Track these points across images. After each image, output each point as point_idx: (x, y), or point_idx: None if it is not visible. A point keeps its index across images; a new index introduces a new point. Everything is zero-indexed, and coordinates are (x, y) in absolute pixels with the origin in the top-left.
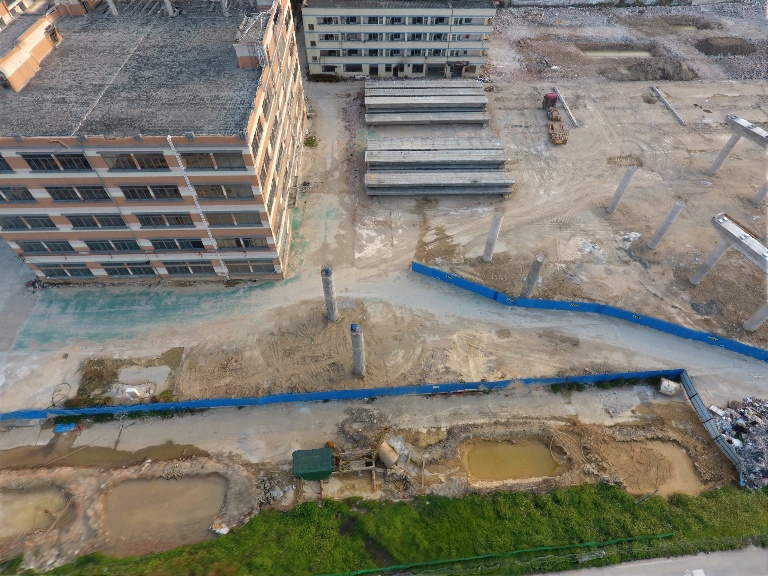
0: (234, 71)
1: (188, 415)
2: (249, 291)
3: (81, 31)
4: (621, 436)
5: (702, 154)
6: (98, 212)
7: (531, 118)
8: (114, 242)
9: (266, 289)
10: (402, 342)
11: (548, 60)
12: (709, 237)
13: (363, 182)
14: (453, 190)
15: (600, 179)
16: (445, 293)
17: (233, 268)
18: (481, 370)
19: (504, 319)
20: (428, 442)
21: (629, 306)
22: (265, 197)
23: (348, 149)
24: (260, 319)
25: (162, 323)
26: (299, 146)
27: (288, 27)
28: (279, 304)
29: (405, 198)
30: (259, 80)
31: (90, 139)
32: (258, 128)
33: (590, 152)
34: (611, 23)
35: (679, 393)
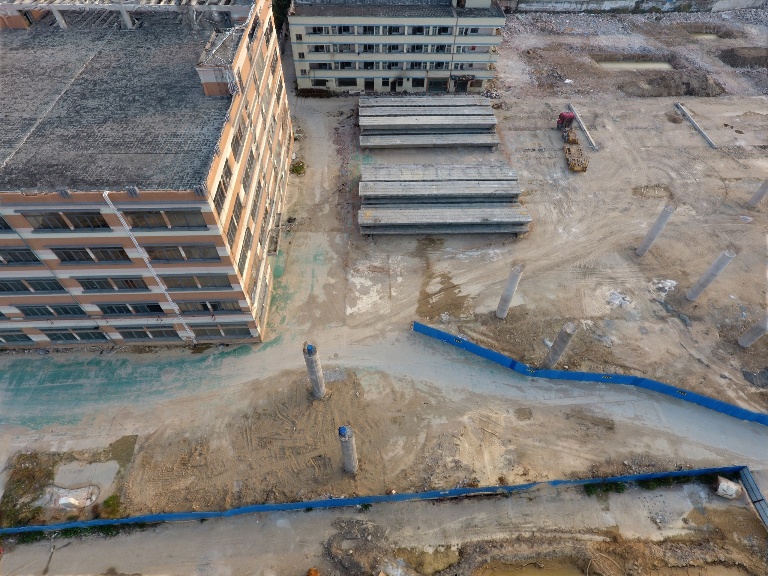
0: (198, 100)
1: (137, 531)
2: (220, 358)
3: (19, 48)
4: (674, 559)
5: (738, 183)
6: (28, 276)
7: (545, 140)
8: (53, 307)
9: (240, 356)
10: (402, 426)
11: (561, 73)
12: (755, 286)
13: (357, 218)
14: (460, 229)
15: (626, 214)
16: (453, 360)
17: (201, 332)
18: (498, 464)
19: (524, 394)
20: (435, 567)
21: (670, 376)
22: (235, 256)
23: (340, 177)
24: (232, 396)
25: (113, 402)
26: (284, 175)
27: (269, 41)
28: (255, 376)
29: (405, 238)
30: (226, 114)
31: (4, 196)
32: (225, 173)
33: (613, 181)
34: (627, 31)
35: (740, 496)
